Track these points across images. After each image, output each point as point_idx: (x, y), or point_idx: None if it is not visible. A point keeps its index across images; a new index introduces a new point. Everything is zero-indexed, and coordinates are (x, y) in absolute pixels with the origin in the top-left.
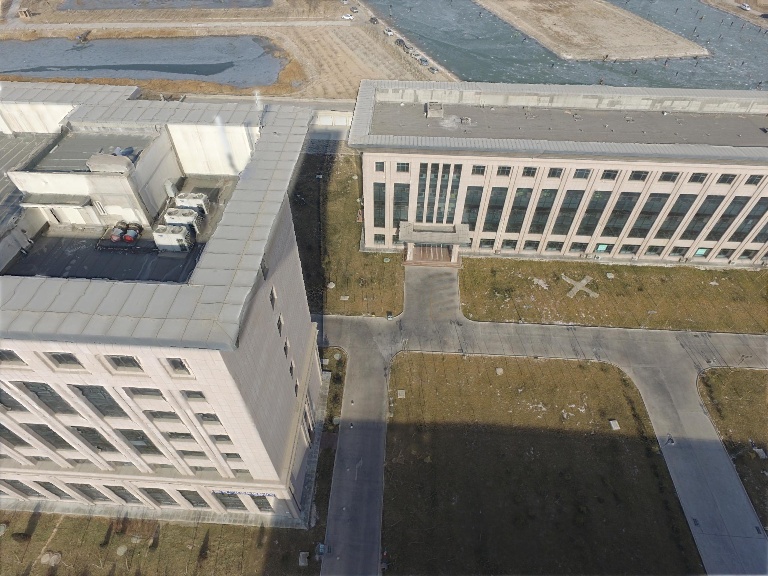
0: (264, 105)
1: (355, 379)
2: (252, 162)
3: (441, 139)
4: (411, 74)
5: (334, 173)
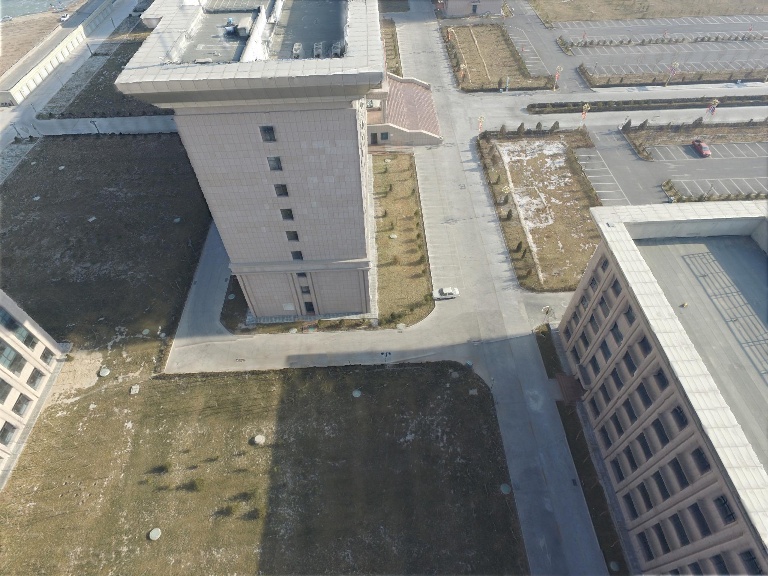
0: None
1: None
2: None
3: None
4: (3, 28)
5: None
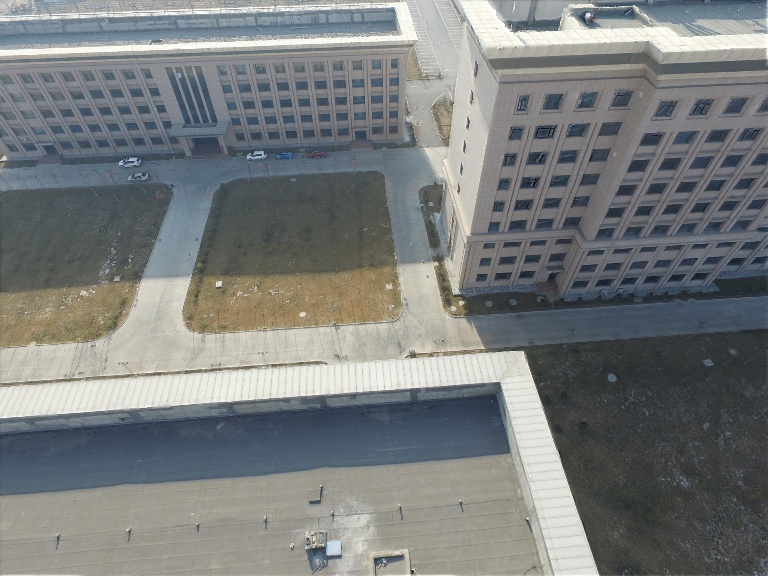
0: (528, 44)
1: (431, 293)
2: (494, 14)
3: (371, 382)
4: None
5: None
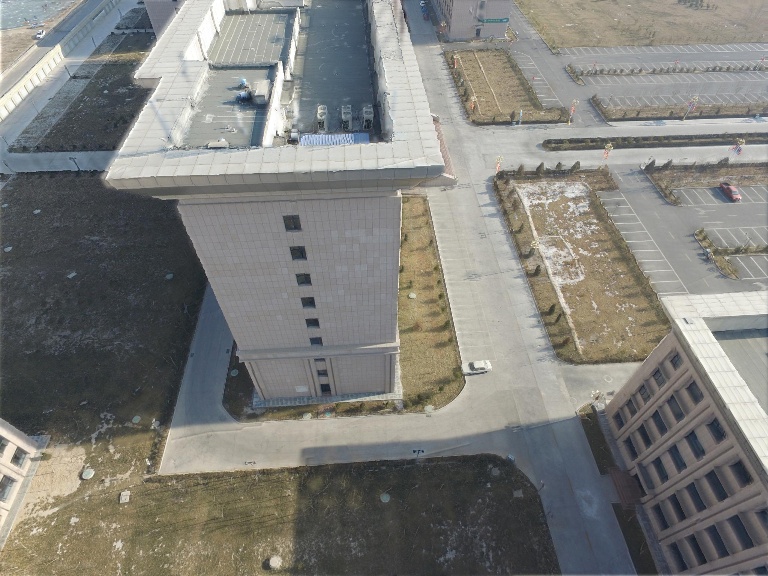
0: None
1: None
2: None
3: None
4: None
5: (133, 59)
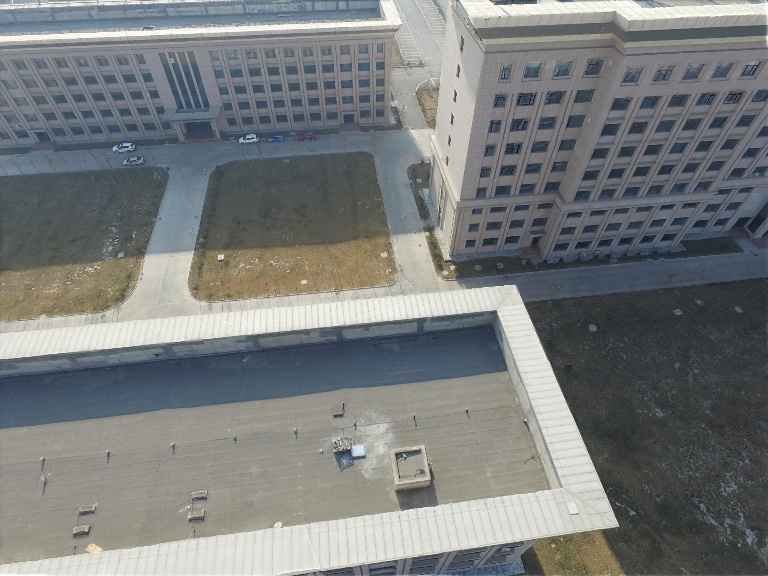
0: (511, 14)
1: (424, 260)
2: None
3: (383, 314)
4: None
5: None
